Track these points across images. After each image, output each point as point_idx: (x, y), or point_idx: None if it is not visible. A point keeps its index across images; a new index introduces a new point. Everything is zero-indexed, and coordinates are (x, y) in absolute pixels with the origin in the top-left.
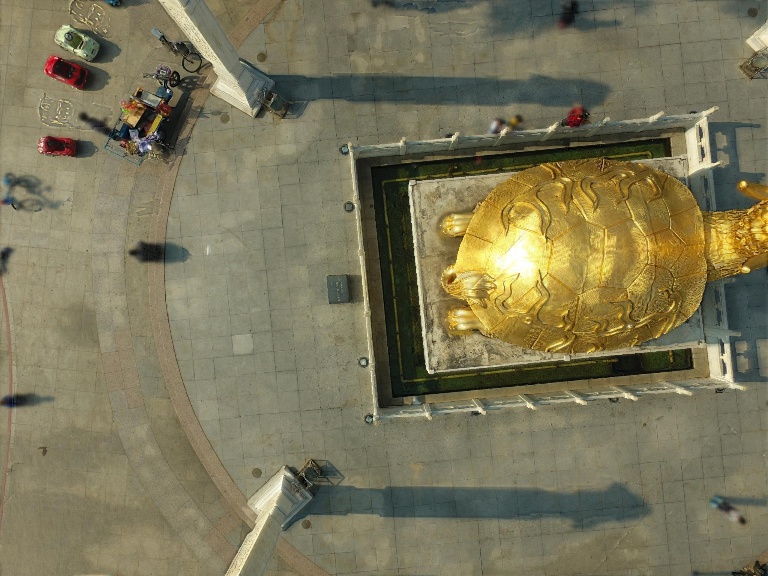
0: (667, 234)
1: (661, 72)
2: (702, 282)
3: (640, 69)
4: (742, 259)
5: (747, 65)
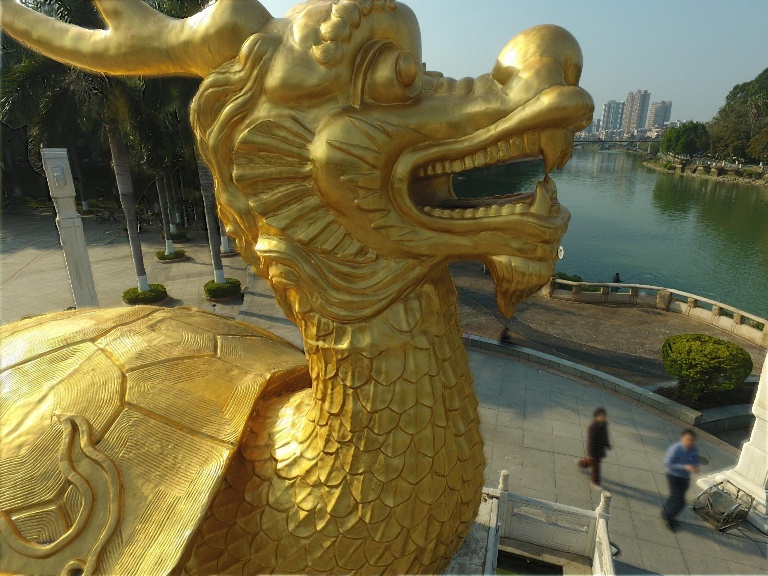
0: (195, 329)
1: (553, 478)
2: (206, 477)
3: (520, 466)
4: (317, 402)
5: (706, 511)
